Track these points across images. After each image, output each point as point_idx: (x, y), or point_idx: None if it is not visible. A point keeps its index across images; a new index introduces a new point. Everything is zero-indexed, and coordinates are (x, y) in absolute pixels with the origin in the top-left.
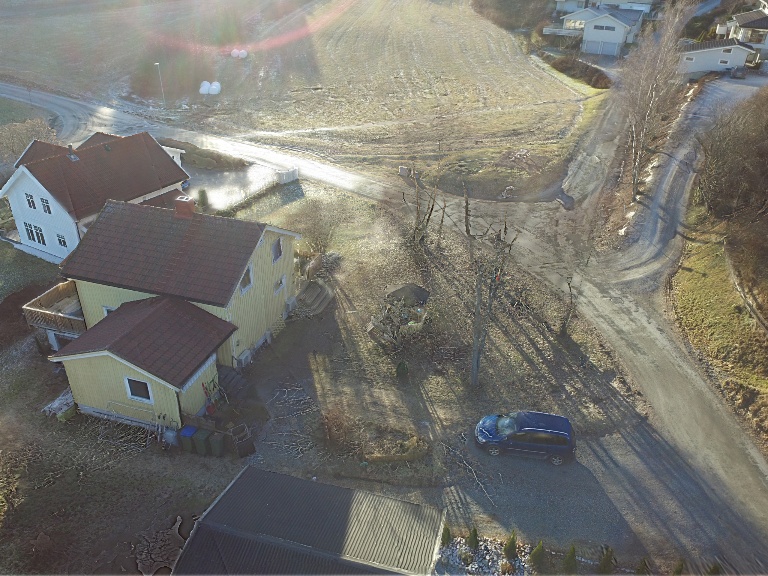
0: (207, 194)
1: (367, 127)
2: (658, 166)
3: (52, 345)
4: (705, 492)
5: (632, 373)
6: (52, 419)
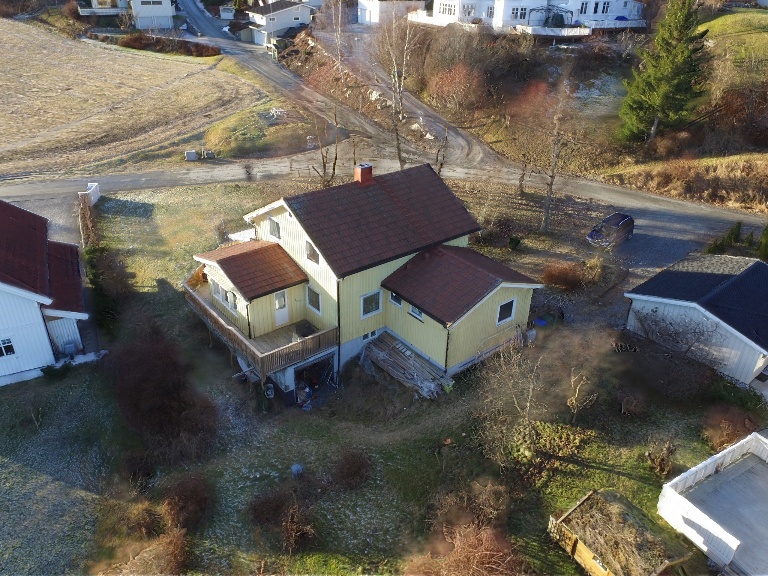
0: None
1: (50, 136)
2: (383, 93)
3: (288, 386)
4: (675, 215)
5: (573, 193)
6: (440, 397)
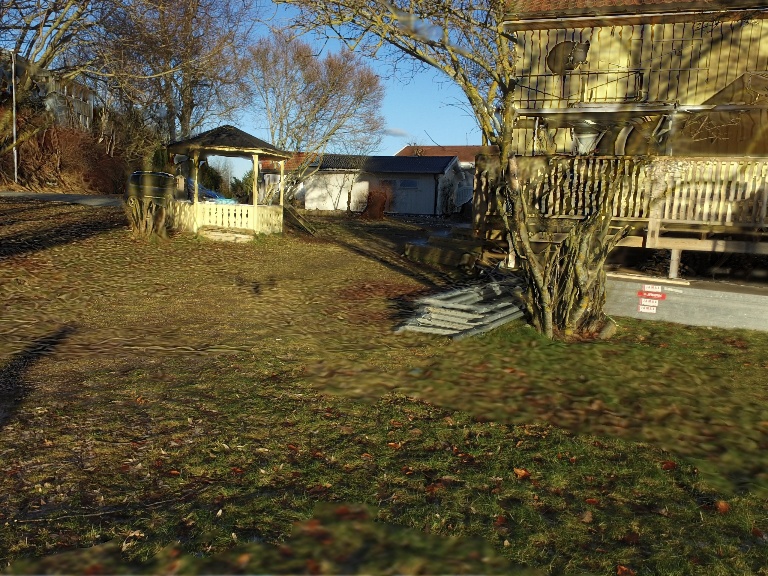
0: None
1: None
2: None
3: None
4: None
5: None
6: None
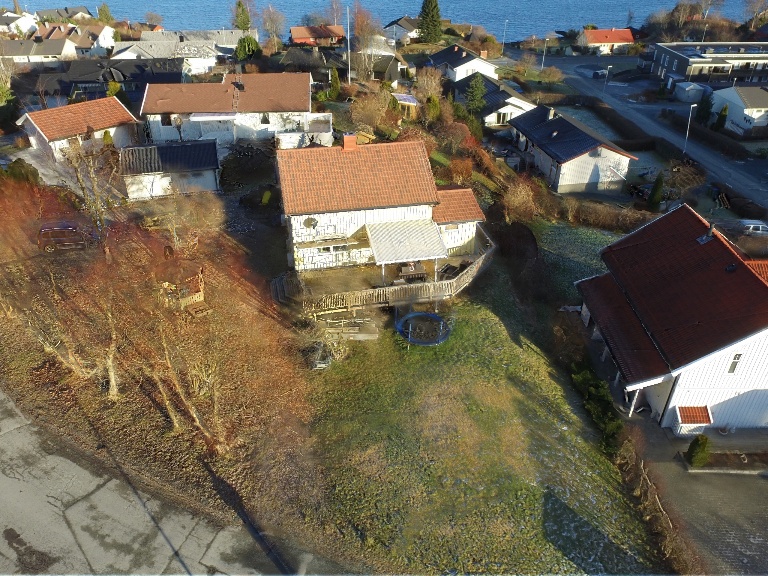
0: (761, 505)
1: None
2: None
3: None
4: None
5: None
6: None
